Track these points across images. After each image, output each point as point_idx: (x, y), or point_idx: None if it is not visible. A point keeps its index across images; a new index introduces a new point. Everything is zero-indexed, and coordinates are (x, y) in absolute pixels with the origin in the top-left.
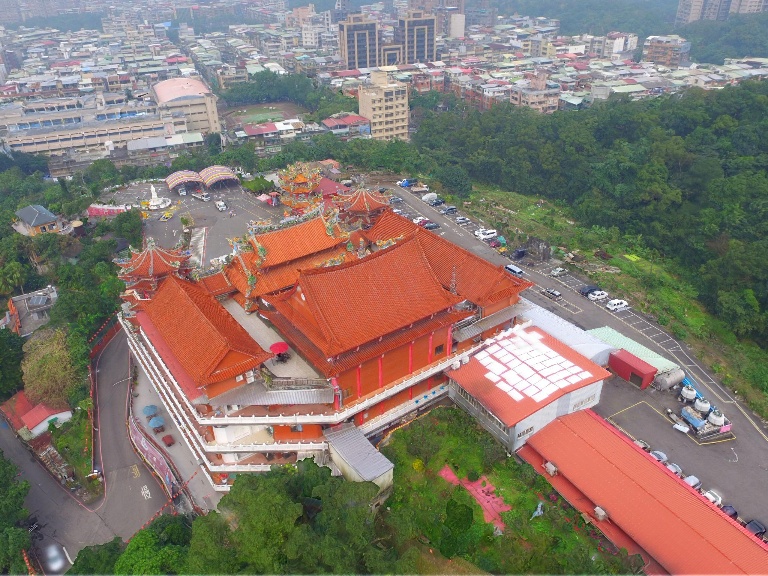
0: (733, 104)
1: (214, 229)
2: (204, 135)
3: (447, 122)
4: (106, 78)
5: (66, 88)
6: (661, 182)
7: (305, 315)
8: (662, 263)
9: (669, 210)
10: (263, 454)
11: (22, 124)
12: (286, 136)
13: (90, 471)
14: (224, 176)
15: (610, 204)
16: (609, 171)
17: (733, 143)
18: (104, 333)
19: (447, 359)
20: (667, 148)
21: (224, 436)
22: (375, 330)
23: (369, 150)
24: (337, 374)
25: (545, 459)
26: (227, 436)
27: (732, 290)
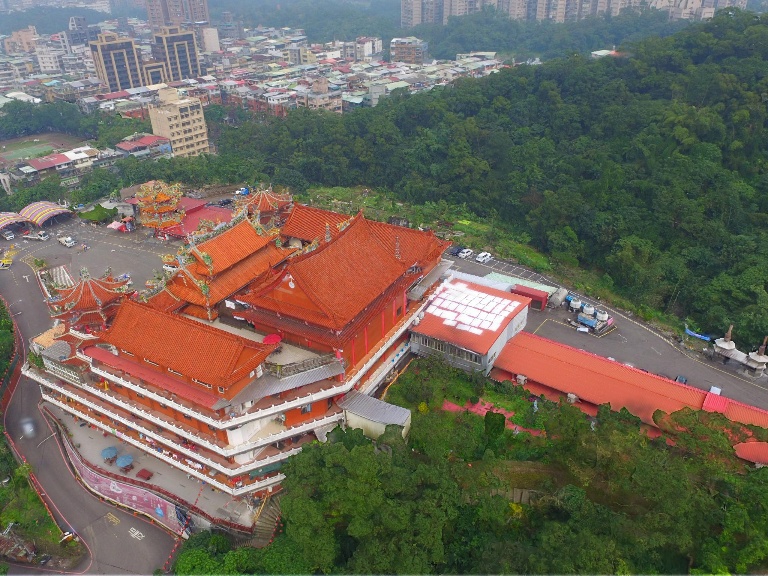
0: (503, 87)
1: (74, 266)
2: None
3: (251, 131)
4: None
5: None
6: (469, 157)
7: (294, 302)
8: (488, 222)
9: (480, 179)
10: (273, 446)
11: None
12: (82, 165)
13: (60, 536)
14: (56, 211)
15: (431, 182)
16: (421, 154)
17: (512, 118)
18: (0, 396)
19: (409, 318)
20: (466, 128)
21: (240, 437)
22: (362, 300)
23: (190, 166)
24: None
25: (514, 374)
26: (242, 436)
27: (556, 229)
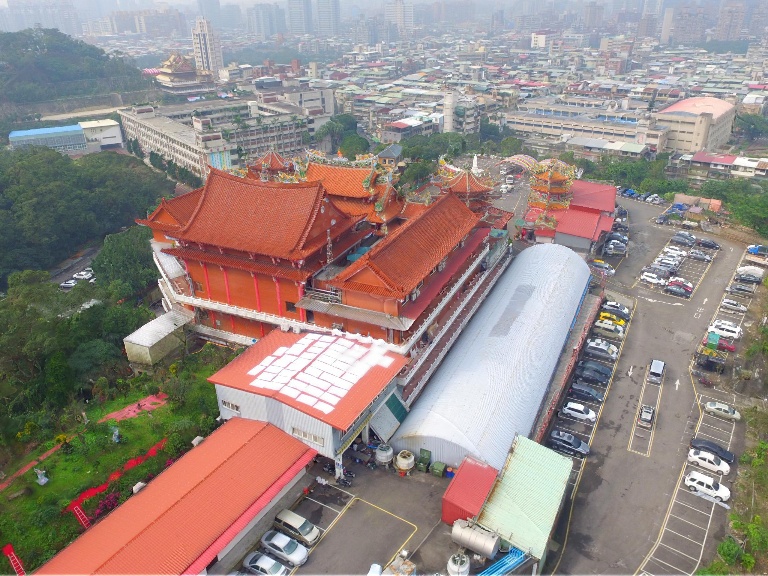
0: None
1: None
2: (651, 149)
3: None
4: (659, 89)
5: (619, 93)
6: None
7: None
8: None
9: None
10: None
11: (539, 110)
12: (739, 173)
13: None
14: None
15: None
16: None
17: None
18: None
19: (284, 317)
20: None
21: None
22: (216, 239)
23: None
24: (182, 258)
25: None
26: None
27: None
